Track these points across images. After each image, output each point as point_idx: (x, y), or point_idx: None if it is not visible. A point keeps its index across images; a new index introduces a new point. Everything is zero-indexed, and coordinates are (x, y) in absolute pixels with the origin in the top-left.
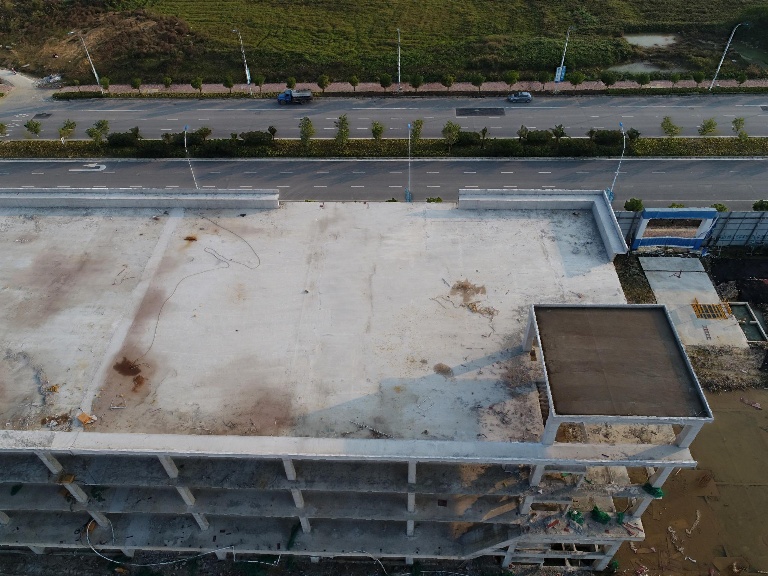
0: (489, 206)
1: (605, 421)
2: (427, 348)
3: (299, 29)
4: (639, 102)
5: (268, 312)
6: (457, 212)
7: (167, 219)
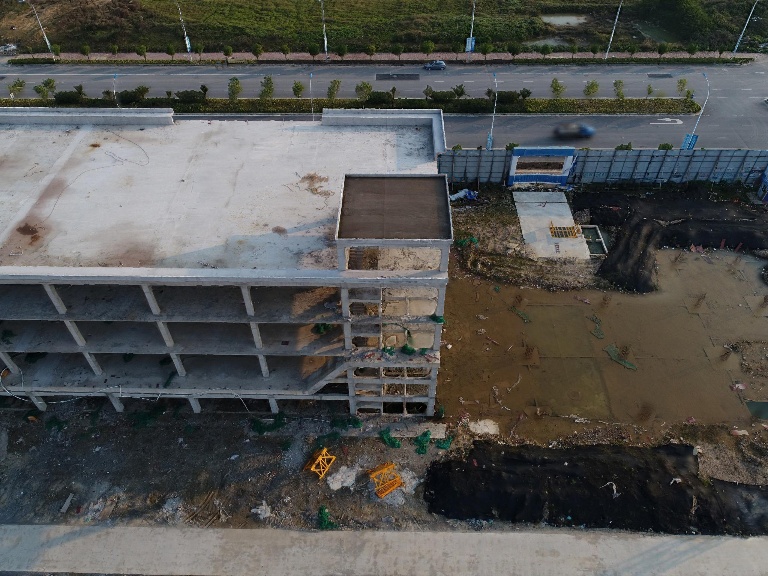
0: (347, 123)
1: (375, 244)
2: (271, 217)
3: (244, 7)
4: (541, 70)
5: (149, 194)
6: (321, 127)
7: (78, 132)
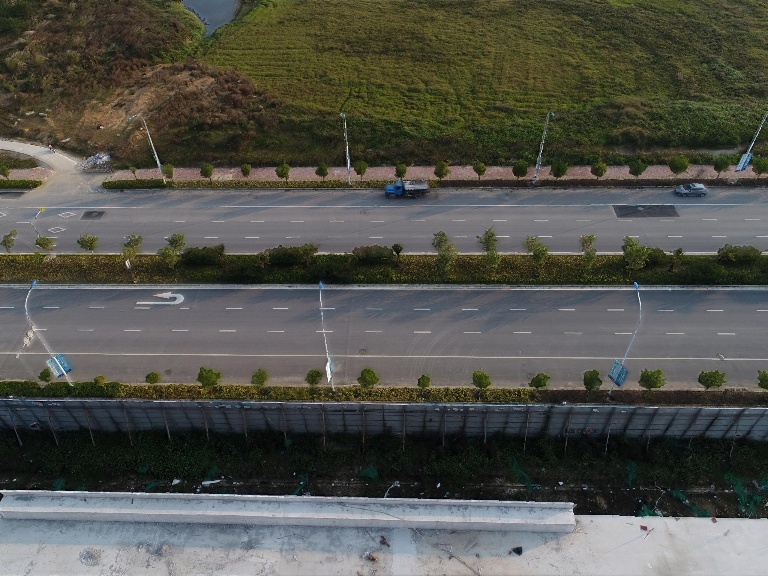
0: None
1: None
2: None
3: (386, 87)
4: None
5: None
6: None
7: (391, 560)
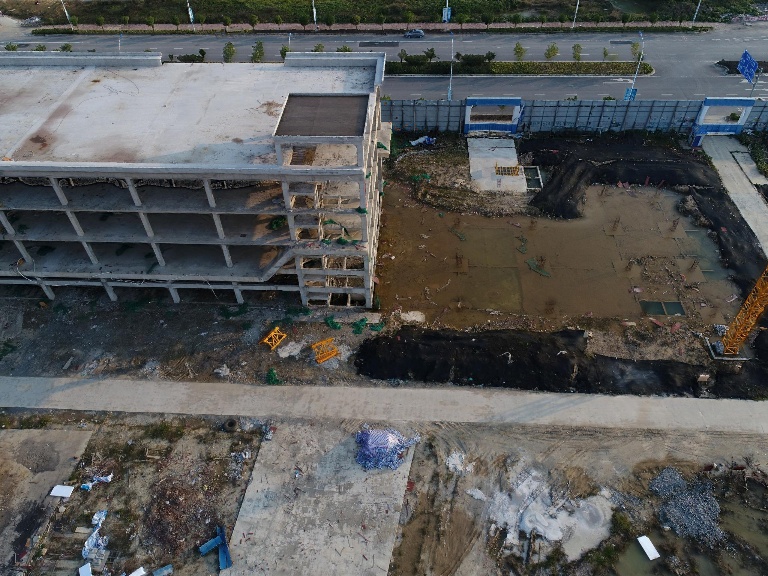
0: (306, 64)
1: (304, 141)
2: (232, 131)
3: None
4: (512, 38)
5: (136, 115)
6: (284, 68)
7: (83, 71)
